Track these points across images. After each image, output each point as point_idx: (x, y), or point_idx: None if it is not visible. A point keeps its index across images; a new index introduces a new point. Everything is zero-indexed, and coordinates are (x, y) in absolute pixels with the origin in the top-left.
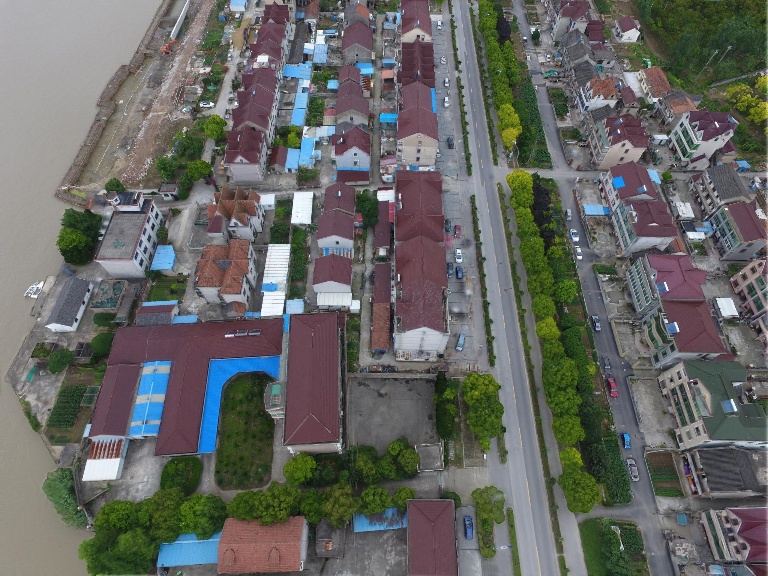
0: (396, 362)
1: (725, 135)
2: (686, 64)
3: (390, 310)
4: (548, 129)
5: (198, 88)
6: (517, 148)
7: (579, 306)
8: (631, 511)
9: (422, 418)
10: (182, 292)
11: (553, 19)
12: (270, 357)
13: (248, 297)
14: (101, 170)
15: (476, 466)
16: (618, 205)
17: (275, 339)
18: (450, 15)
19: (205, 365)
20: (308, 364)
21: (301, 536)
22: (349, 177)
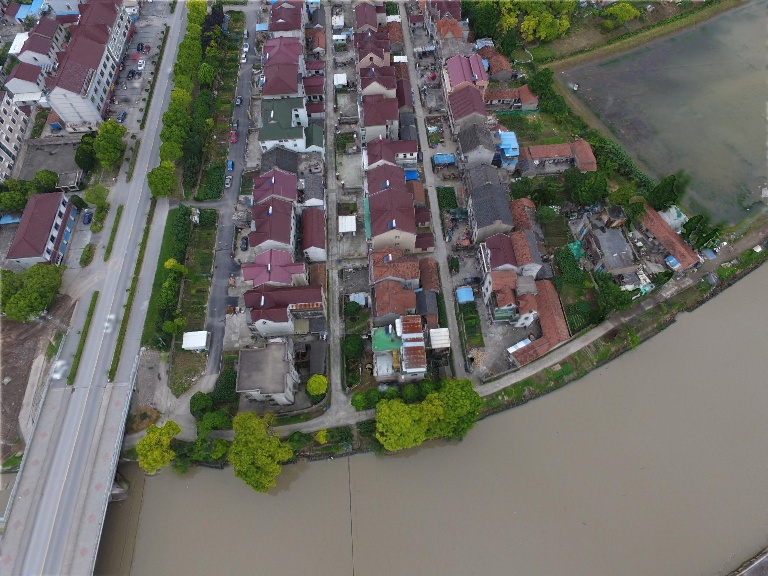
0: (69, 134)
1: None
2: None
3: None
4: None
5: None
6: None
7: (232, 92)
8: (218, 204)
9: None
10: None
11: None
12: None
13: None
14: None
15: (108, 186)
16: None
17: None
18: None
19: None
20: None
21: None
22: (66, 20)
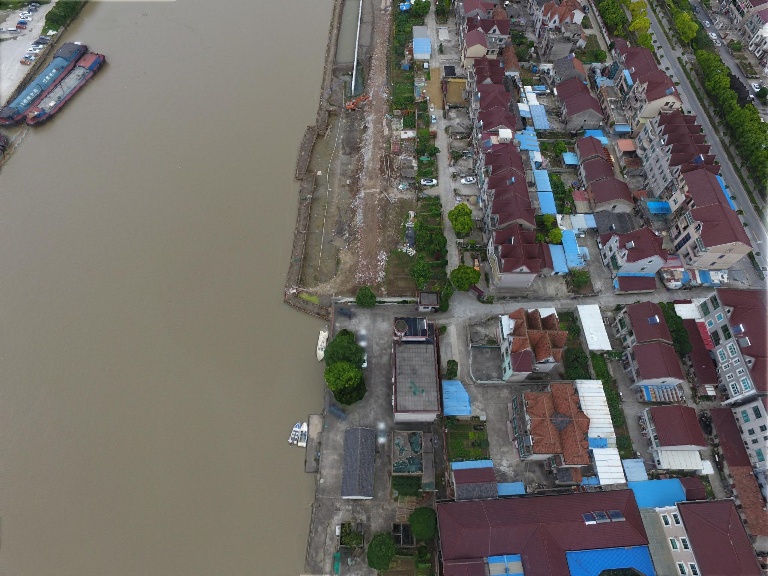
0: None
1: None
2: None
3: (755, 477)
4: None
5: (412, 160)
6: None
7: None
8: None
9: None
10: (487, 444)
11: None
12: (635, 547)
13: None
14: (323, 264)
15: None
16: None
17: (637, 522)
18: (659, 66)
19: (564, 561)
20: None
21: None
22: (633, 285)
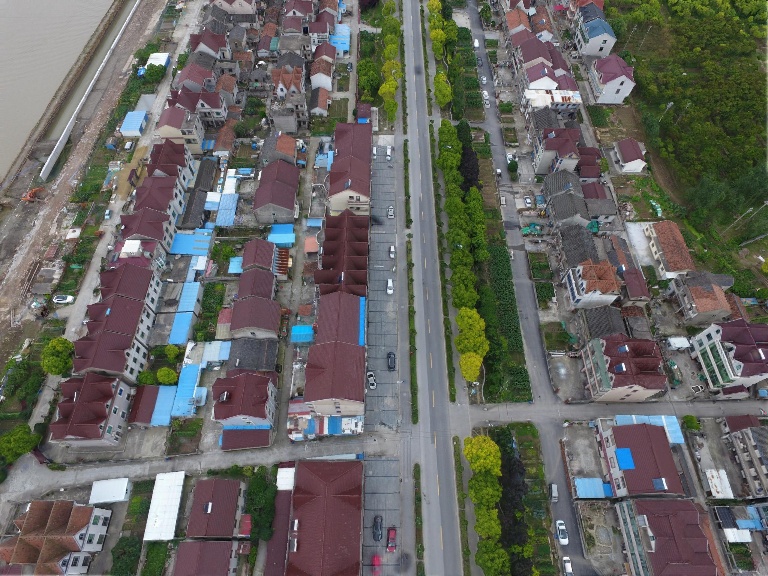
0: None
1: None
2: (708, 216)
3: None
4: (527, 325)
5: (55, 270)
6: (483, 368)
7: None
8: None
9: None
10: None
11: (535, 144)
12: None
13: None
14: None
15: None
16: (625, 496)
17: None
18: (404, 136)
19: None
20: None
21: None
22: (240, 441)
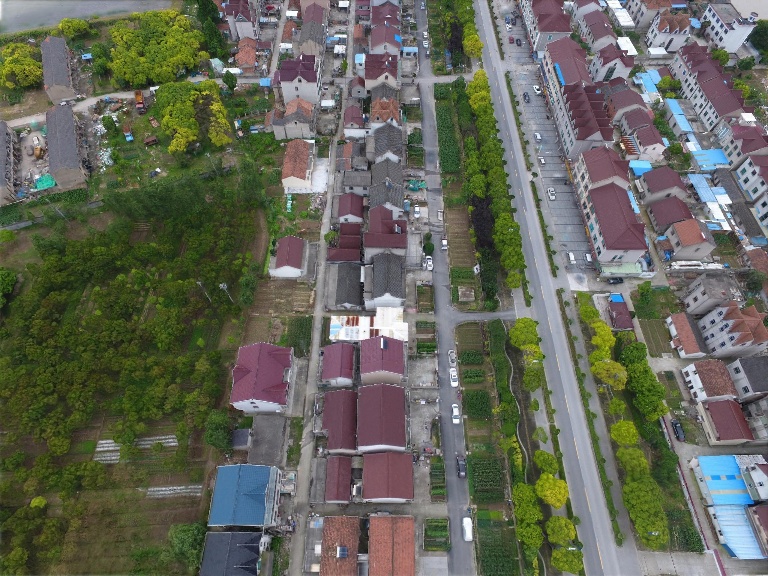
0: None
1: None
2: None
3: None
4: (431, 122)
5: None
6: None
7: None
8: None
9: None
10: None
11: None
12: None
13: None
14: None
15: None
16: None
17: None
18: (559, 288)
19: None
20: None
21: None
22: None
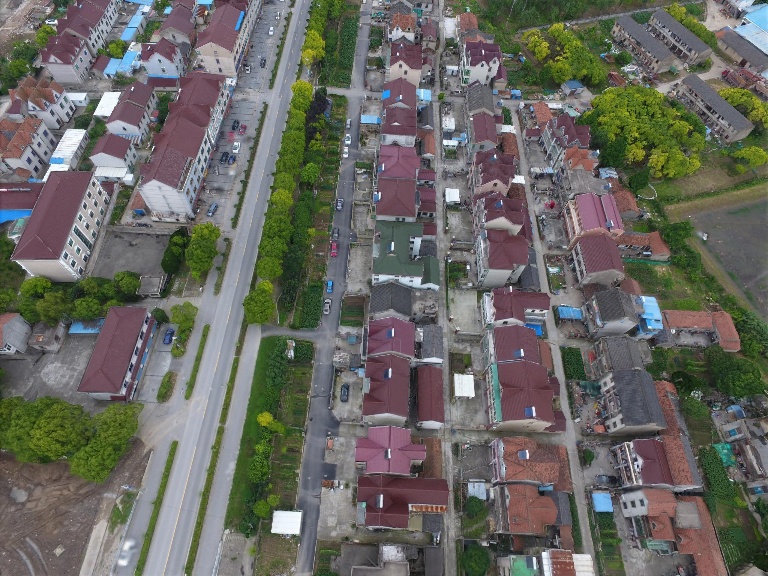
0: (153, 222)
1: (493, 63)
2: None
3: None
4: (359, 58)
5: (48, 8)
6: (321, 70)
7: (332, 192)
8: (315, 334)
9: (160, 262)
10: None
11: None
12: None
13: (38, 168)
14: None
15: (193, 296)
16: None
17: None
18: None
19: None
20: (48, 202)
21: (7, 322)
22: (158, 83)
